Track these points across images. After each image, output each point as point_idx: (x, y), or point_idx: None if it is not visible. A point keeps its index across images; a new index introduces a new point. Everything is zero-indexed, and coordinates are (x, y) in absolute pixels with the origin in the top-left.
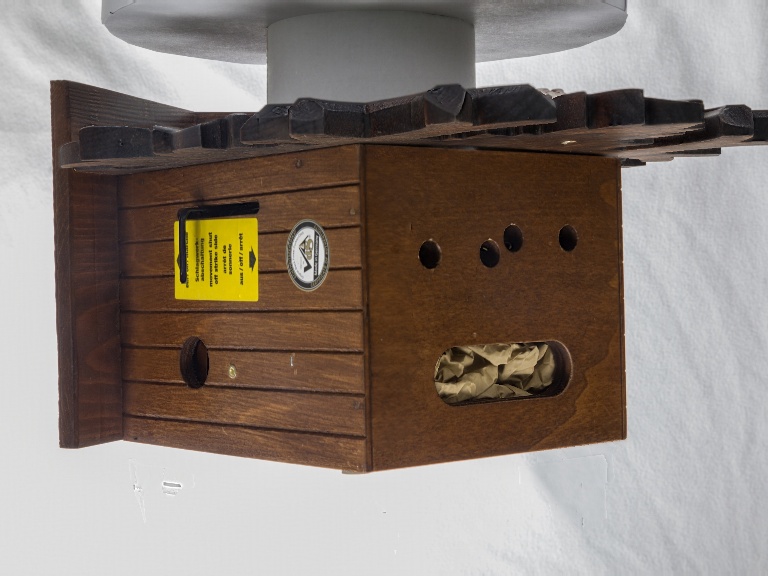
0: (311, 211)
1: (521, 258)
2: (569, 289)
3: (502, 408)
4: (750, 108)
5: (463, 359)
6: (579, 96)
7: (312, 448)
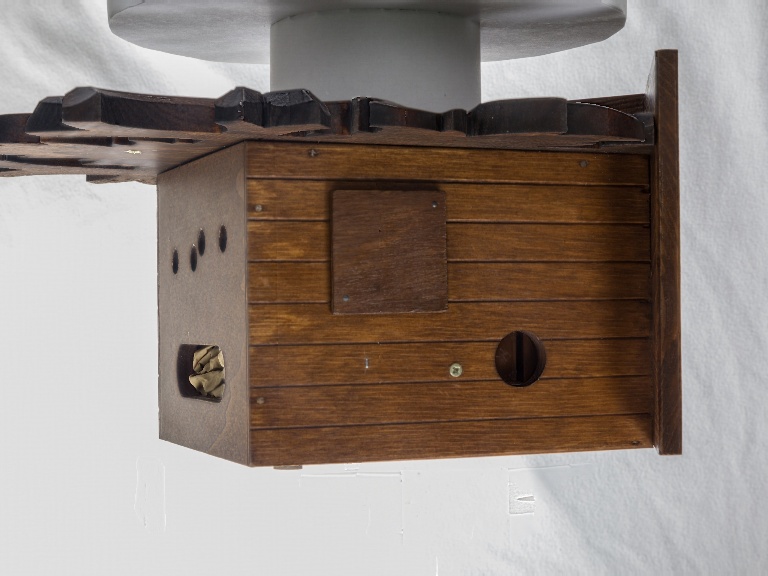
0: None
1: (204, 261)
2: (223, 292)
3: (198, 406)
4: (38, 101)
5: (215, 357)
6: None
7: None
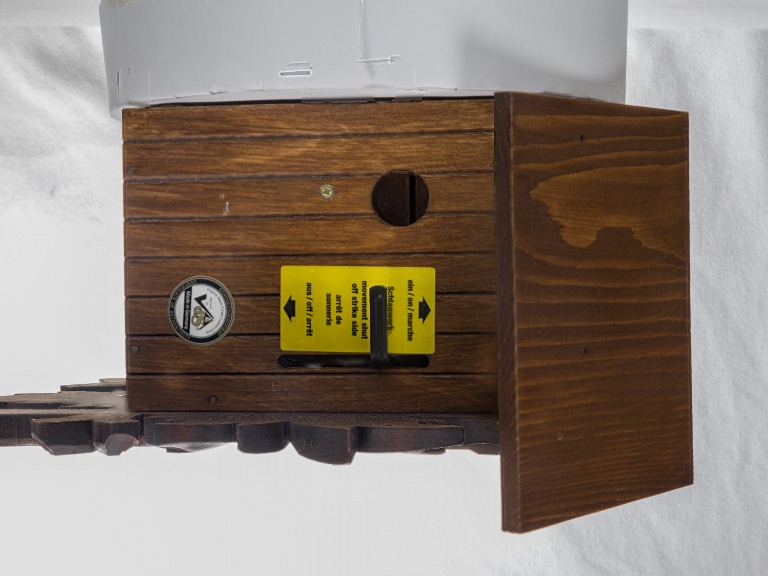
0: (194, 353)
1: None
2: None
3: None
4: None
5: None
6: None
7: (198, 124)
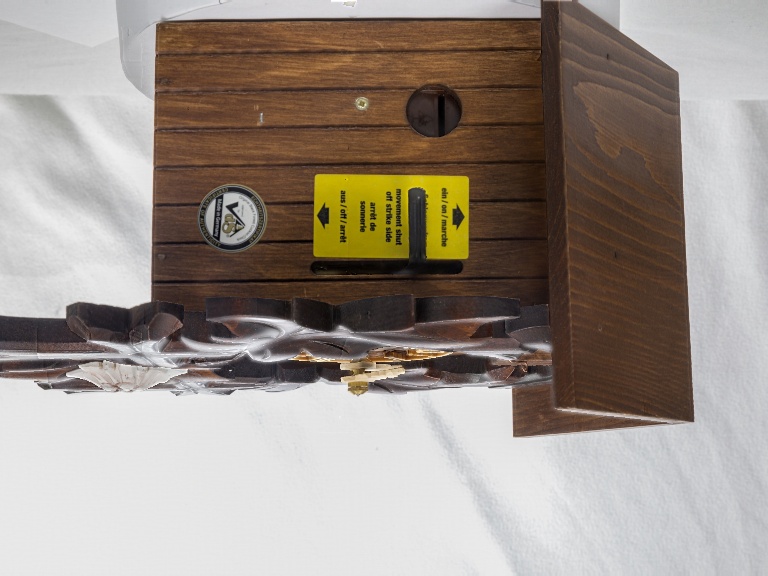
0: (224, 260)
1: None
2: None
3: None
4: None
5: None
6: (8, 366)
7: (233, 39)
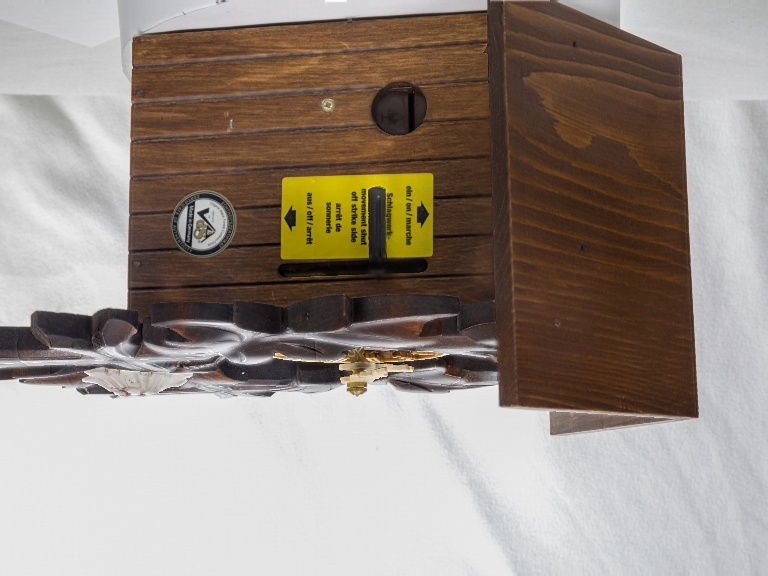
0: (196, 265)
1: None
2: None
3: None
4: None
5: None
6: (17, 373)
7: (205, 48)
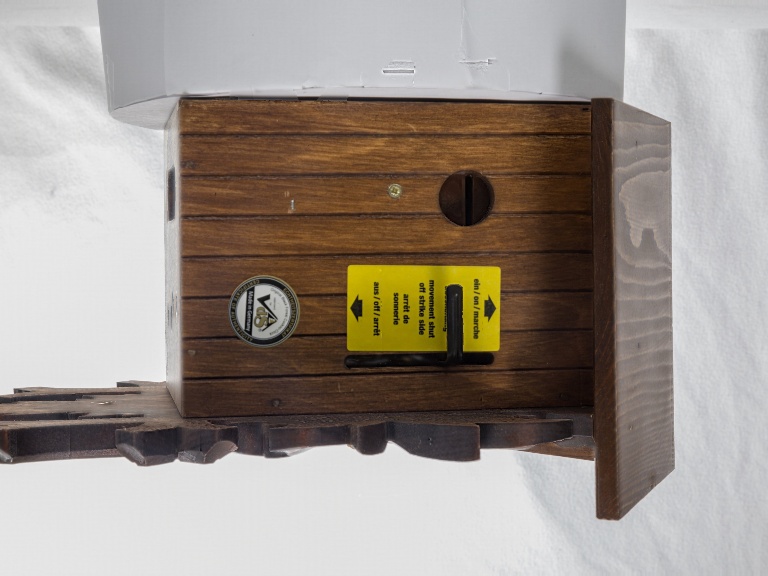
0: (257, 355)
1: None
2: None
3: None
4: None
5: None
6: None
7: (261, 119)
